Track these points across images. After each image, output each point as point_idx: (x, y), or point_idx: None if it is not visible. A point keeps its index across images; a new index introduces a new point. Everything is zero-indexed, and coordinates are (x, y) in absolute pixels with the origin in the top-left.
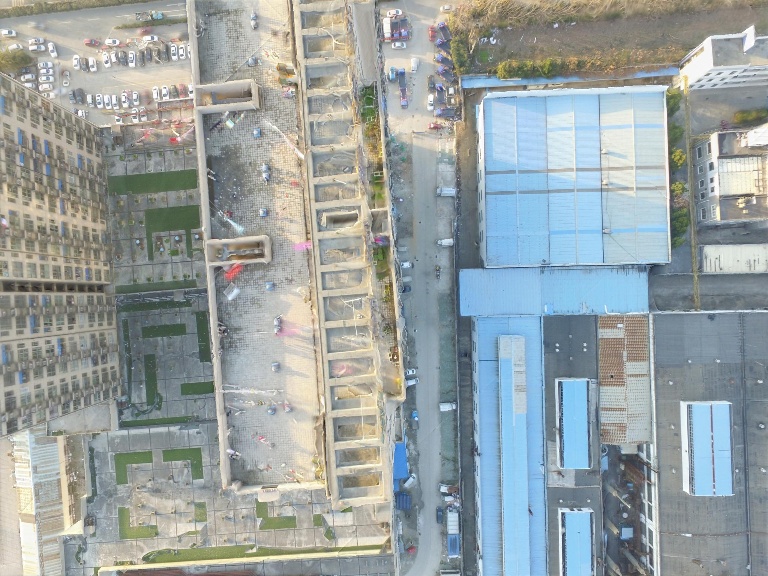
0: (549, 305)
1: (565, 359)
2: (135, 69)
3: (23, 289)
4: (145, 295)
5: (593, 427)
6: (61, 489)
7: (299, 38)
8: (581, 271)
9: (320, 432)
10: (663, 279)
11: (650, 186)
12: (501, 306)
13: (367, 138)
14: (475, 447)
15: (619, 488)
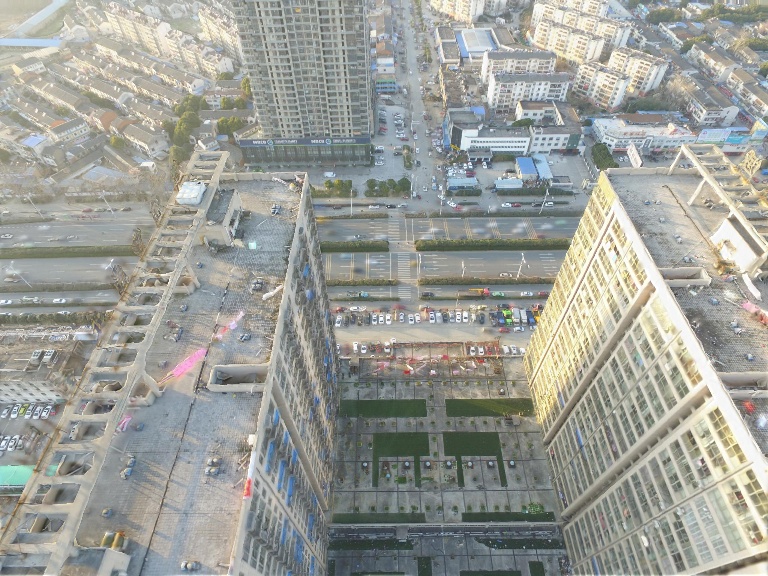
0: None
1: None
2: (339, 328)
3: None
4: (360, 530)
5: None
6: None
7: (761, 237)
8: None
9: None
10: None
11: None
12: None
13: None
14: None
15: None
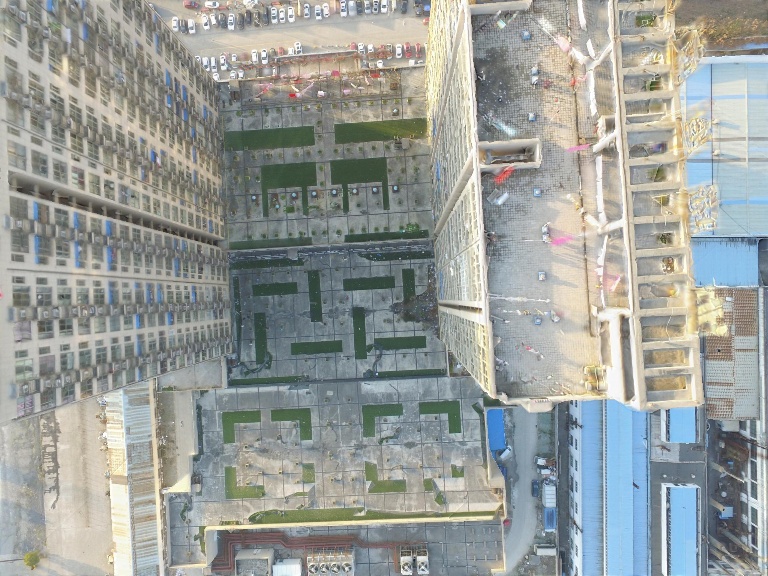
0: None
1: None
2: (234, 32)
3: (166, 232)
4: (257, 253)
5: None
6: (152, 451)
7: None
8: None
9: (605, 339)
10: (766, 255)
11: (762, 158)
12: None
13: None
14: (573, 420)
15: None
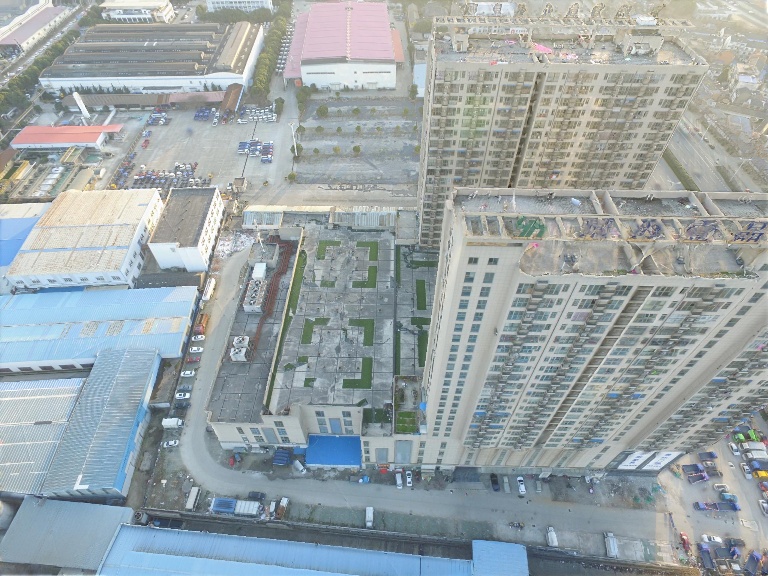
0: None
1: None
2: None
3: None
4: None
5: None
6: None
7: None
8: None
9: None
10: None
11: None
12: None
13: (710, 274)
14: None
15: None
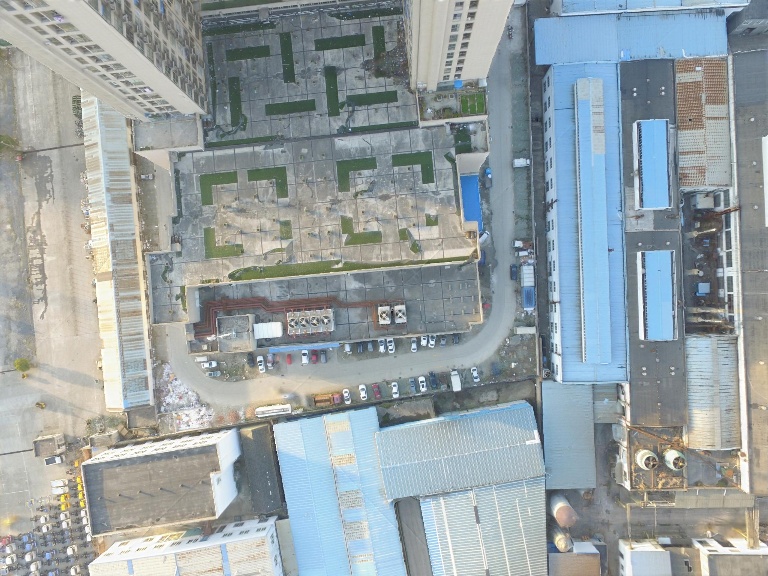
0: (626, 51)
1: (642, 104)
2: None
3: None
4: (229, 18)
5: (672, 169)
6: (136, 249)
7: None
8: (658, 16)
9: None
10: (737, 39)
11: None
12: (577, 53)
13: None
14: (549, 203)
15: (694, 248)
